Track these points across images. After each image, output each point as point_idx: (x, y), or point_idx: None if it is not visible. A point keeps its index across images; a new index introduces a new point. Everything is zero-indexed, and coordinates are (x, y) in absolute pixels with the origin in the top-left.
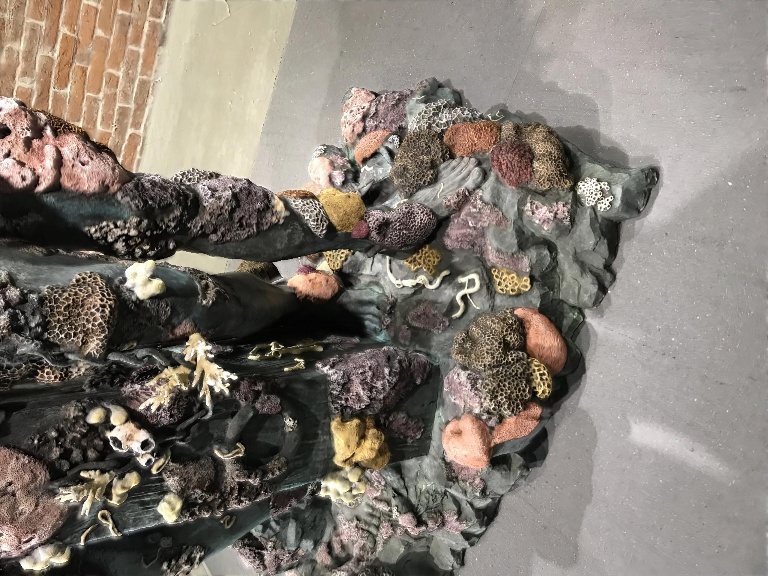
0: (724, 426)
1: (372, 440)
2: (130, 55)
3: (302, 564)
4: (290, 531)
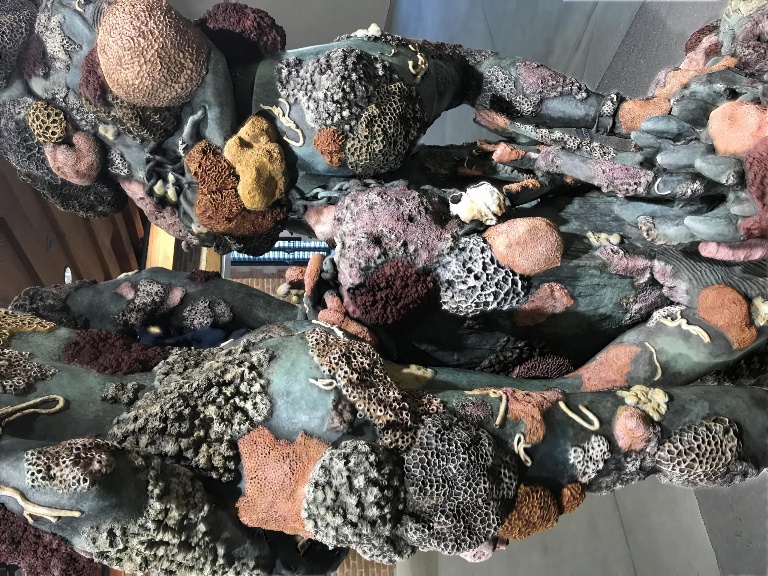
0: (761, 505)
1: None
2: None
3: None
4: None
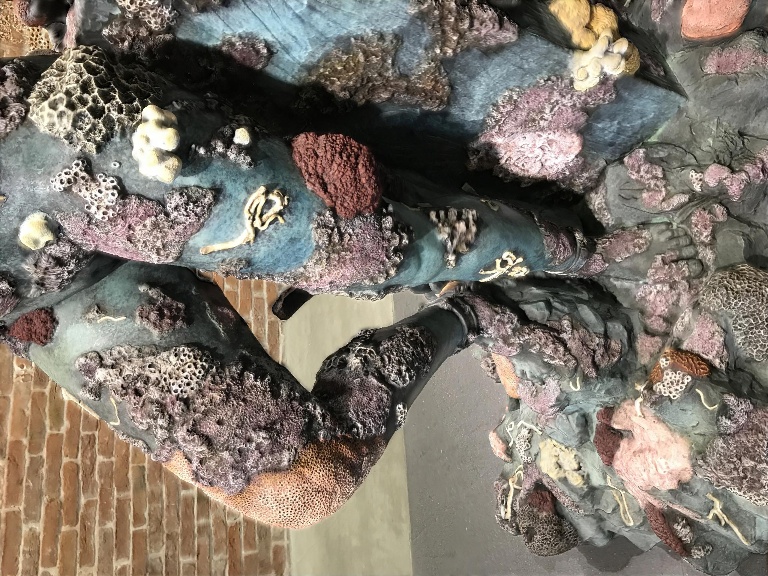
0: None
1: (603, 7)
2: (257, 303)
3: (627, 379)
4: (584, 313)
